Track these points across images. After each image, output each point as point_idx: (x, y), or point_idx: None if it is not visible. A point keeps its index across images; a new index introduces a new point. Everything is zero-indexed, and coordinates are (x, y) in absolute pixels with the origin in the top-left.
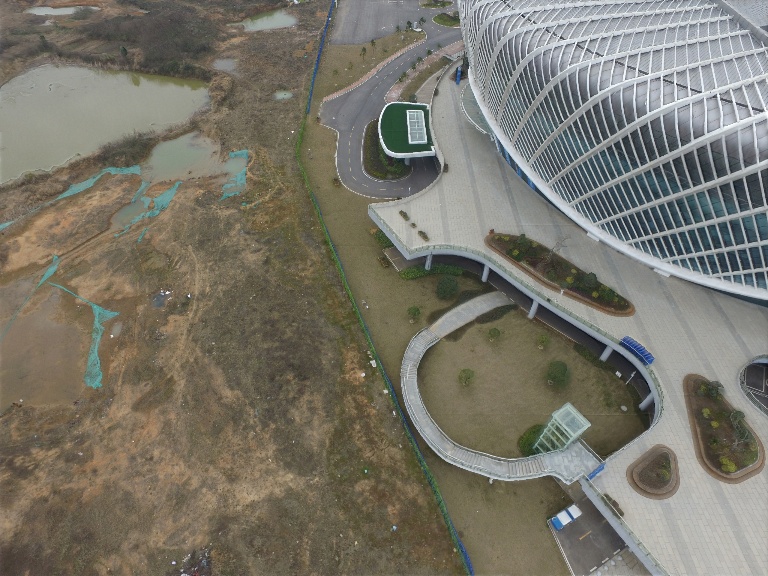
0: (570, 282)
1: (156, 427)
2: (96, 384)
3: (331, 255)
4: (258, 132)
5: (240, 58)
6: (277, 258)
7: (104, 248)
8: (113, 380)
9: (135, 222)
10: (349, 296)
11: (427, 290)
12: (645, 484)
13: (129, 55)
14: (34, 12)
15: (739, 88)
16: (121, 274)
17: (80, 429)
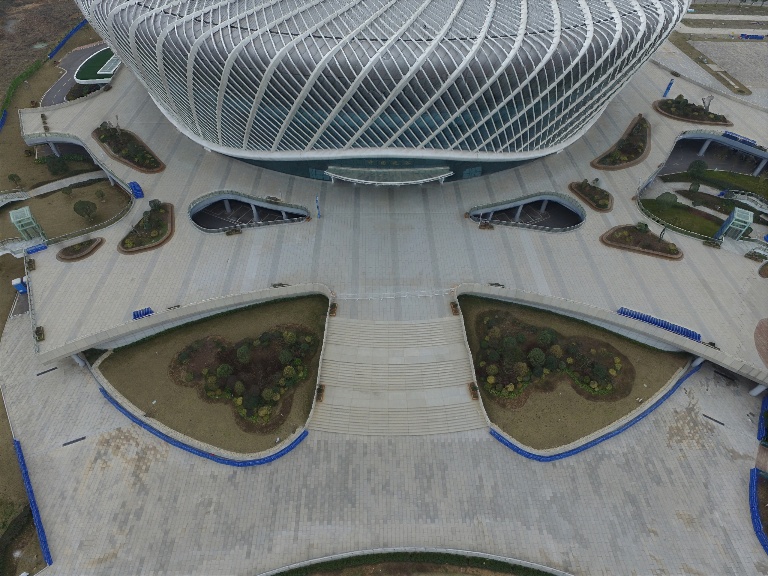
0: (124, 152)
1: None
2: None
3: None
4: None
5: (22, 19)
6: None
7: None
8: None
9: None
10: None
11: (47, 170)
12: (63, 254)
13: None
14: None
15: None
16: None
17: None
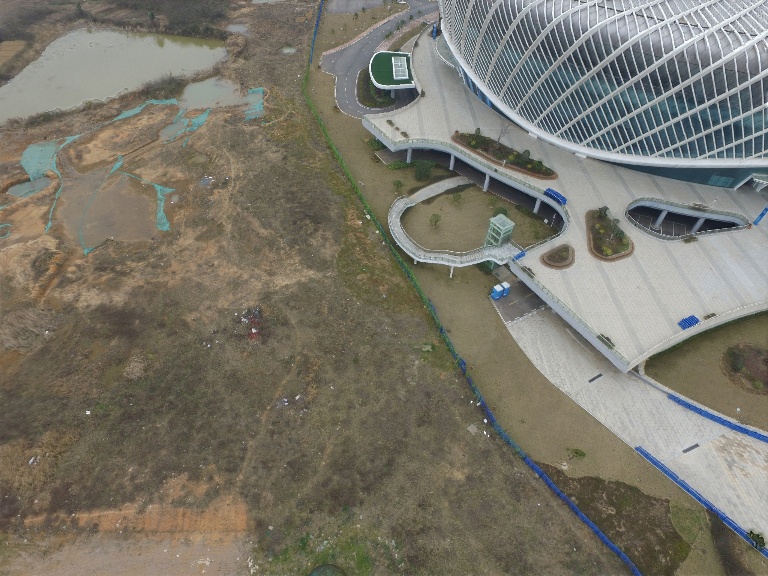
0: (512, 159)
1: (214, 249)
2: (166, 228)
3: (334, 155)
4: (270, 76)
5: (250, 23)
6: (293, 156)
7: (157, 151)
8: (178, 226)
9: (179, 134)
10: (349, 178)
11: (408, 175)
12: (551, 261)
13: (155, 20)
14: None
15: None
16: (173, 166)
17: (159, 251)
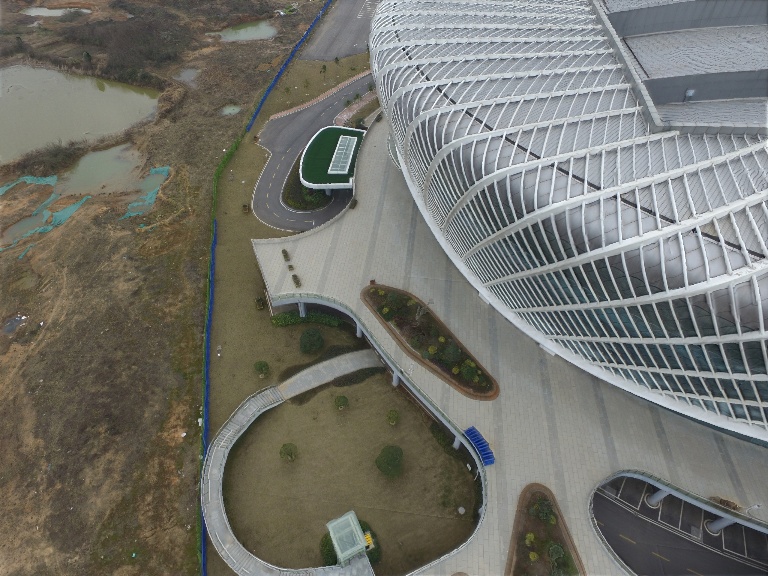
0: (432, 352)
1: None
2: None
3: None
4: (188, 148)
5: (203, 69)
6: (149, 289)
7: None
8: None
9: (25, 237)
10: None
11: (293, 341)
12: None
13: (95, 60)
14: (32, 12)
15: (584, 157)
16: None
17: None
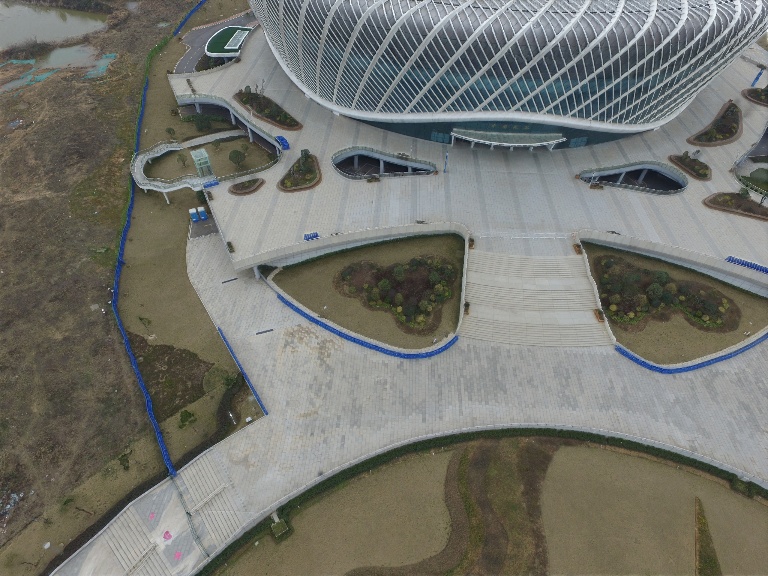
0: (267, 112)
1: None
2: None
3: None
4: (130, 44)
5: (143, 1)
6: (102, 107)
7: None
8: None
9: (17, 87)
10: None
11: (193, 127)
12: (234, 189)
13: None
14: None
15: None
16: None
17: None
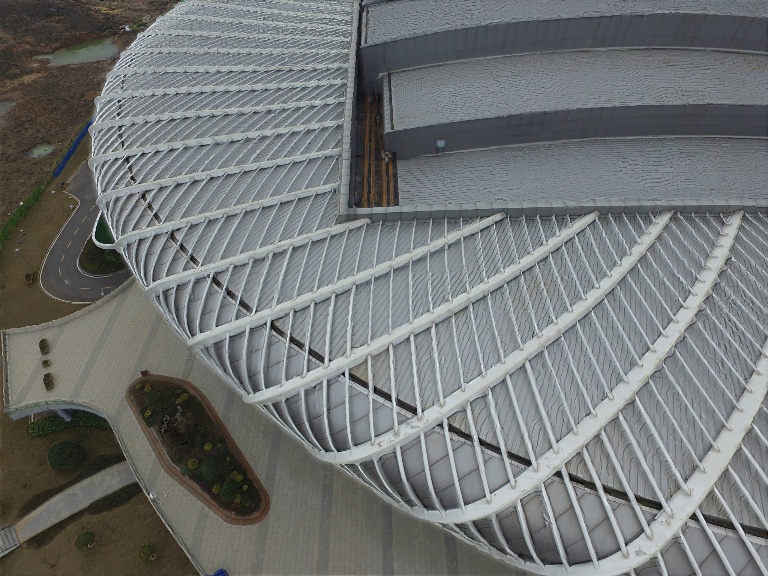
0: (191, 467)
1: None
2: None
3: None
4: None
5: (17, 102)
6: None
7: None
8: None
9: None
10: None
11: None
12: None
13: None
14: None
15: (248, 263)
16: None
17: None
